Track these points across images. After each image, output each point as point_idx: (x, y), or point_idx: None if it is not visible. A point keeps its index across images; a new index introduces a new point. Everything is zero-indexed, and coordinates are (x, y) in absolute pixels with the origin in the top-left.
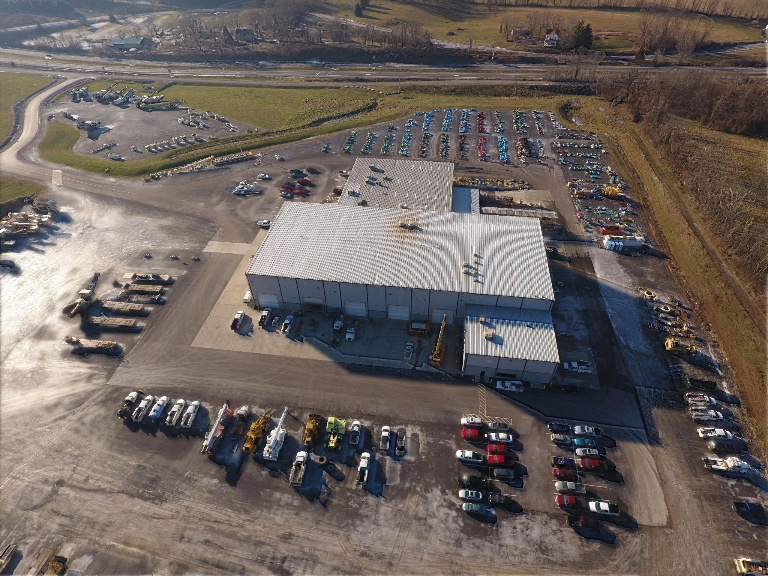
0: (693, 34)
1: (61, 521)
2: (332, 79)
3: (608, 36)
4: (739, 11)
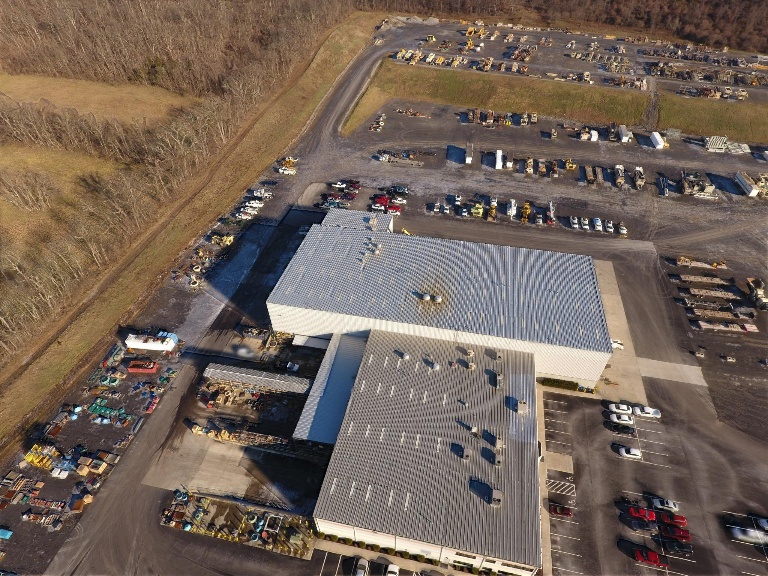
0: None
1: (607, 194)
2: None
3: None
4: None
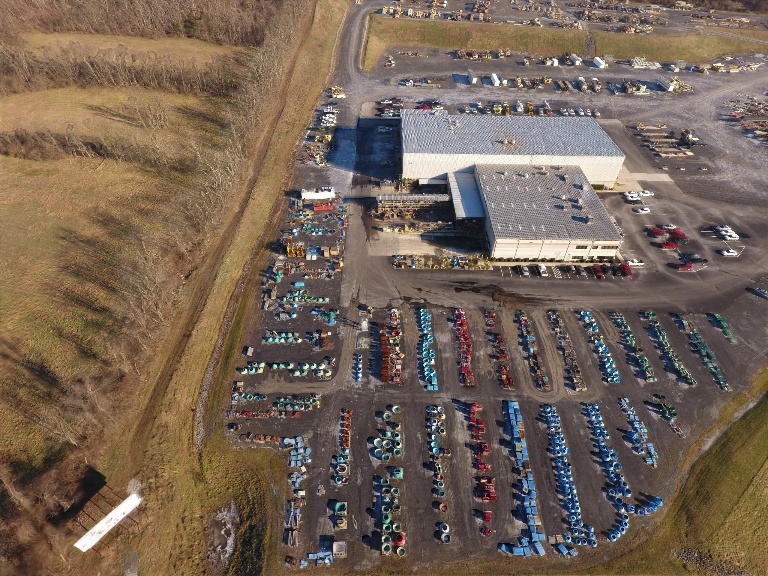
0: None
1: (578, 96)
2: None
3: None
4: None
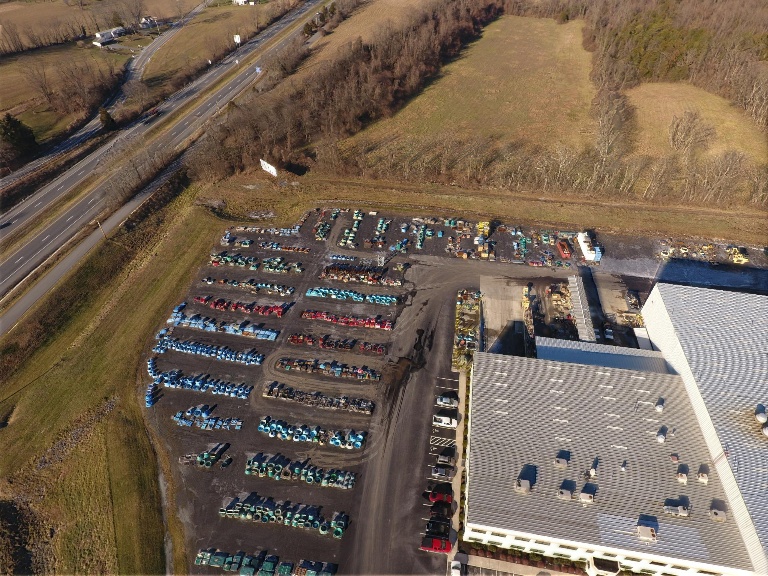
0: (100, 74)
1: None
2: None
3: None
4: (47, 38)
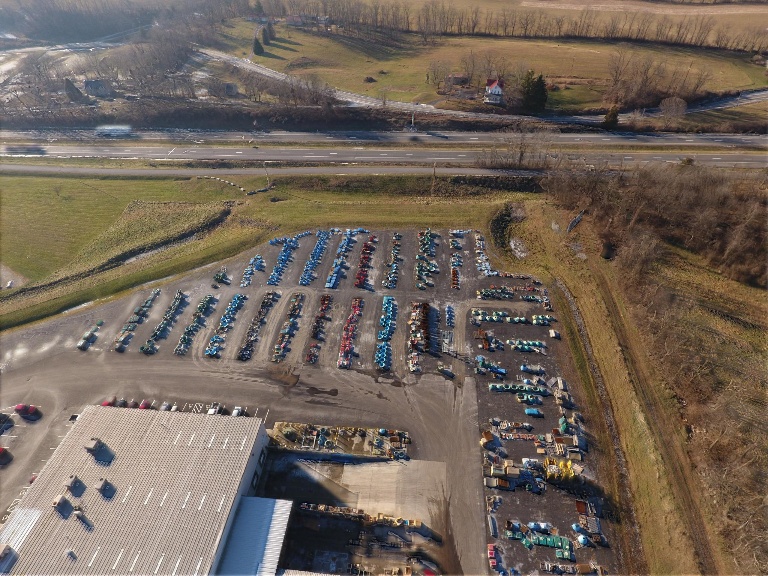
0: (682, 84)
1: None
2: (184, 163)
3: (569, 85)
4: (736, 42)
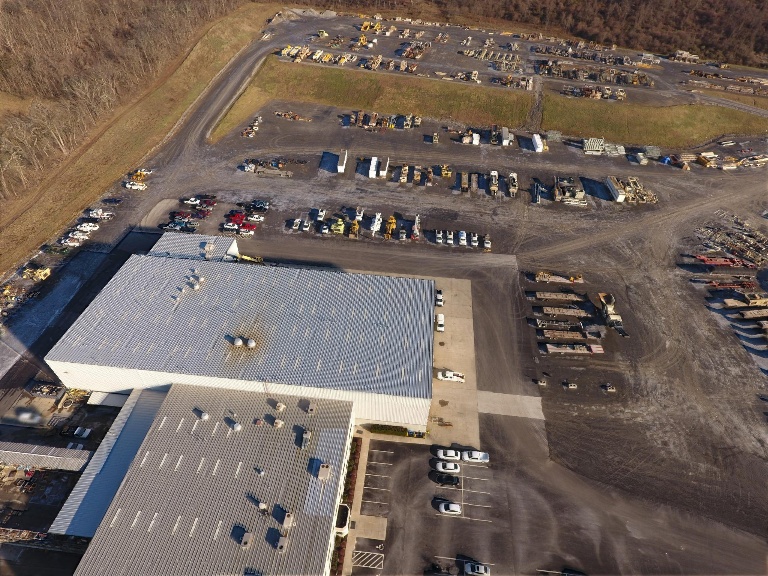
0: None
1: (479, 203)
2: None
3: None
4: None
